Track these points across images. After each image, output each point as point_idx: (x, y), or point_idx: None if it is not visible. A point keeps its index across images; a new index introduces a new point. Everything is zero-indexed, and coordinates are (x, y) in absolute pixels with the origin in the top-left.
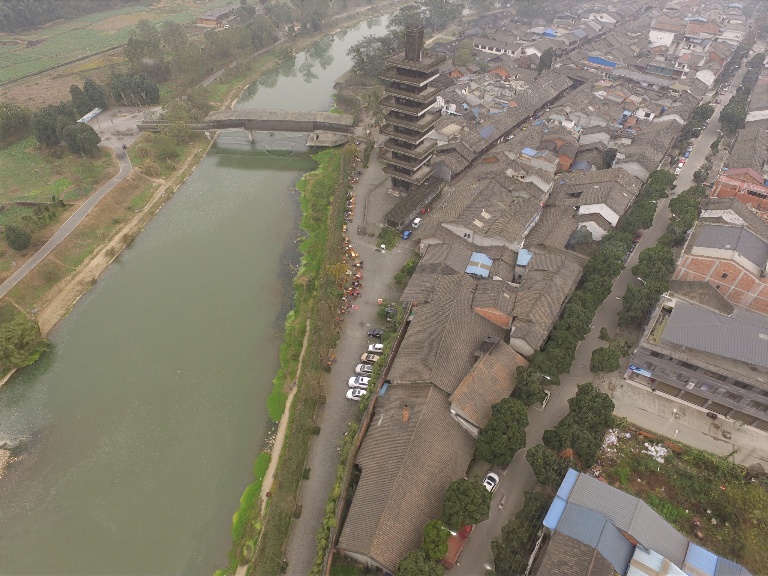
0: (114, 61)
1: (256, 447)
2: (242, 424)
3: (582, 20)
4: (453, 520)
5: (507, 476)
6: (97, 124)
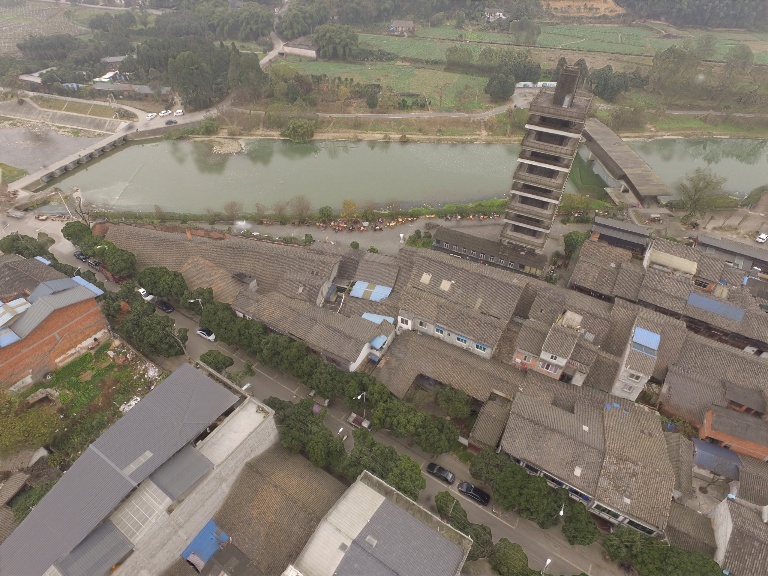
0: None
1: None
2: None
3: None
4: None
5: None
6: None
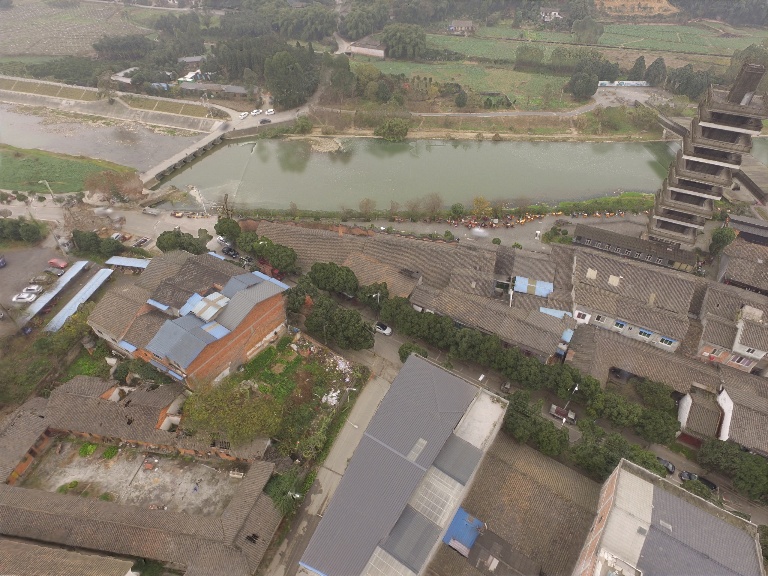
0: None
1: None
2: (357, 206)
3: None
4: None
5: None
6: (625, 90)
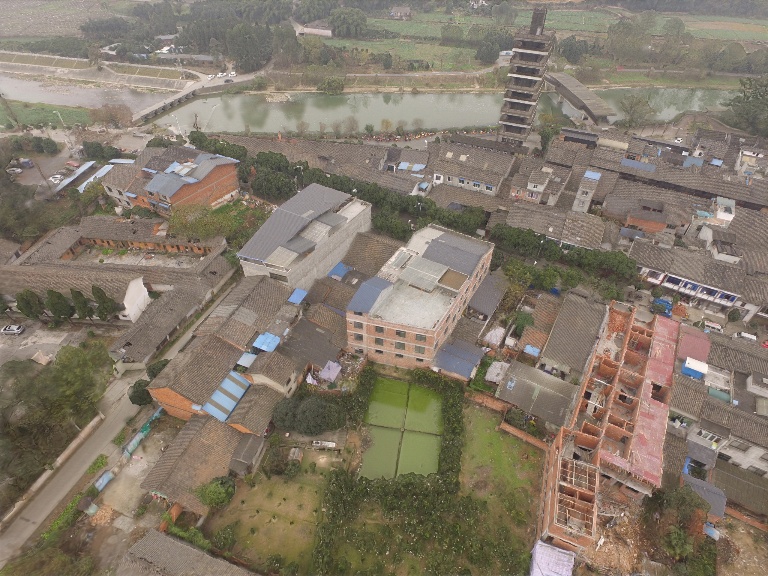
0: None
1: None
2: None
3: None
4: None
5: None
6: None
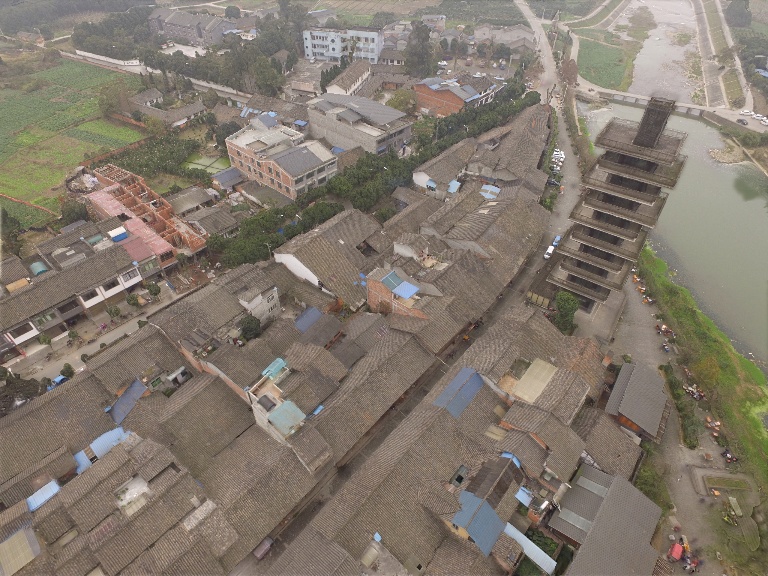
0: None
1: None
2: None
3: None
4: None
5: None
6: None
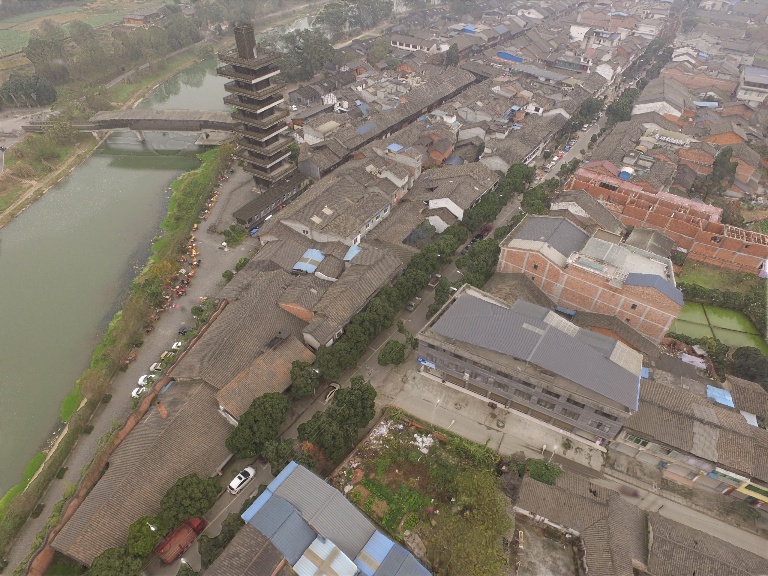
0: (25, 62)
1: (36, 448)
2: (29, 425)
3: (507, 16)
4: (163, 515)
5: (266, 470)
6: None
